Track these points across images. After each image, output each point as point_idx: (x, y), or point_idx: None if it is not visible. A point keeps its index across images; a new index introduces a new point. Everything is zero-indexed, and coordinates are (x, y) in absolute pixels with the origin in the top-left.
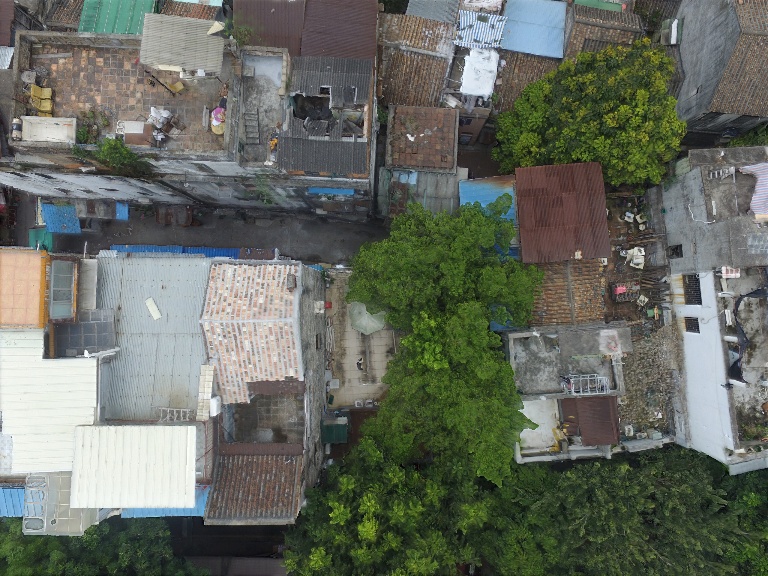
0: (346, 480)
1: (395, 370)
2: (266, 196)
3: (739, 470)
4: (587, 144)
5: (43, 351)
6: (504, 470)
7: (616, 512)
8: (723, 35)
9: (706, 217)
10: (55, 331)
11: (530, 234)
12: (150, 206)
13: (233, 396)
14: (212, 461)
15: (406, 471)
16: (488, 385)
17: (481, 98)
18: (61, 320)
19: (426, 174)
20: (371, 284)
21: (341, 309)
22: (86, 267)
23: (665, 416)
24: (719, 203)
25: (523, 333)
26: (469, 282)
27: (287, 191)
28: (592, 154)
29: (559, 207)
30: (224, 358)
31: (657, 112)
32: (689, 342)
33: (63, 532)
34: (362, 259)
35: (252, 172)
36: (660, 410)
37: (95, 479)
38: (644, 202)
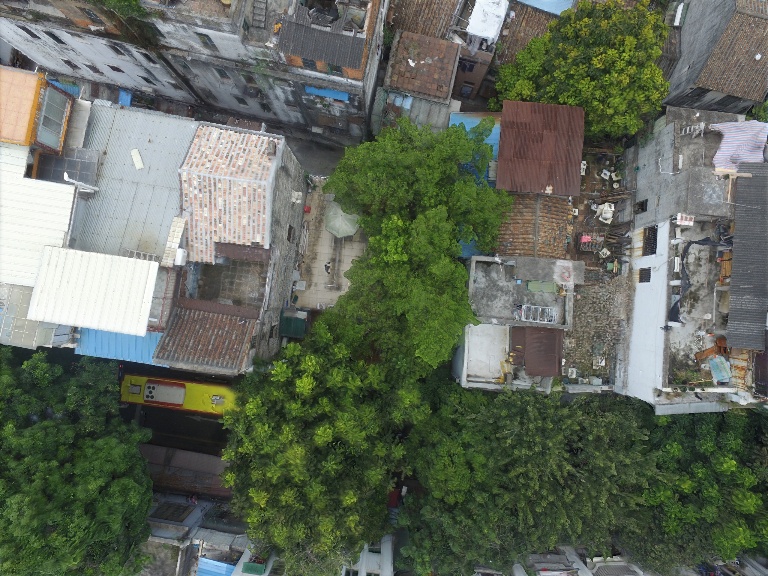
0: (293, 346)
1: (358, 266)
2: (265, 99)
3: (664, 412)
4: (574, 87)
5: (25, 170)
6: (441, 354)
7: (543, 432)
8: (720, 15)
9: (672, 169)
10: (40, 161)
11: (507, 163)
12: (153, 100)
13: (199, 254)
14: (169, 310)
15: (353, 361)
16: (442, 287)
17: (486, 42)
18: (47, 147)
19: (421, 101)
20: (349, 179)
21: (319, 215)
22: (79, 106)
23: (608, 367)
24: (687, 160)
25: (486, 257)
26: (442, 195)
27: (286, 93)
28: (578, 99)
29: (539, 143)
30: (196, 213)
31: (641, 57)
32: (640, 293)
33: (16, 343)
34: (345, 160)
35: (253, 55)
36: (603, 354)
37: (55, 296)
38: (621, 162)
